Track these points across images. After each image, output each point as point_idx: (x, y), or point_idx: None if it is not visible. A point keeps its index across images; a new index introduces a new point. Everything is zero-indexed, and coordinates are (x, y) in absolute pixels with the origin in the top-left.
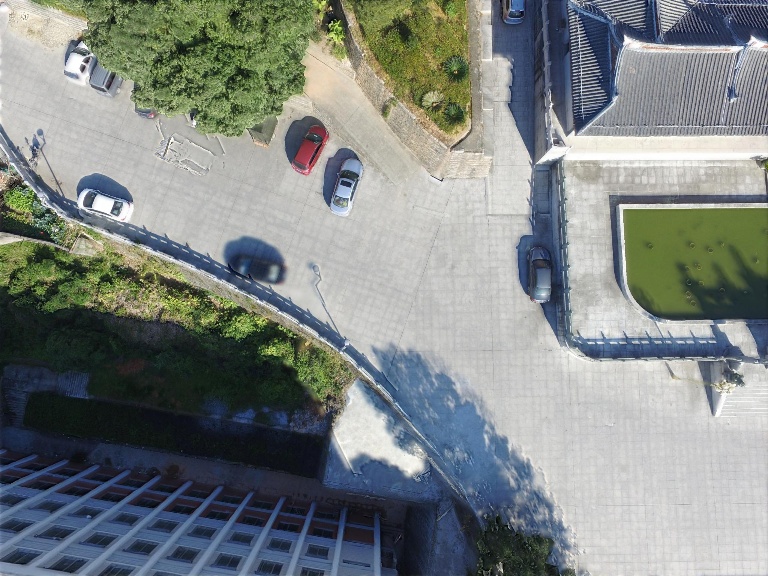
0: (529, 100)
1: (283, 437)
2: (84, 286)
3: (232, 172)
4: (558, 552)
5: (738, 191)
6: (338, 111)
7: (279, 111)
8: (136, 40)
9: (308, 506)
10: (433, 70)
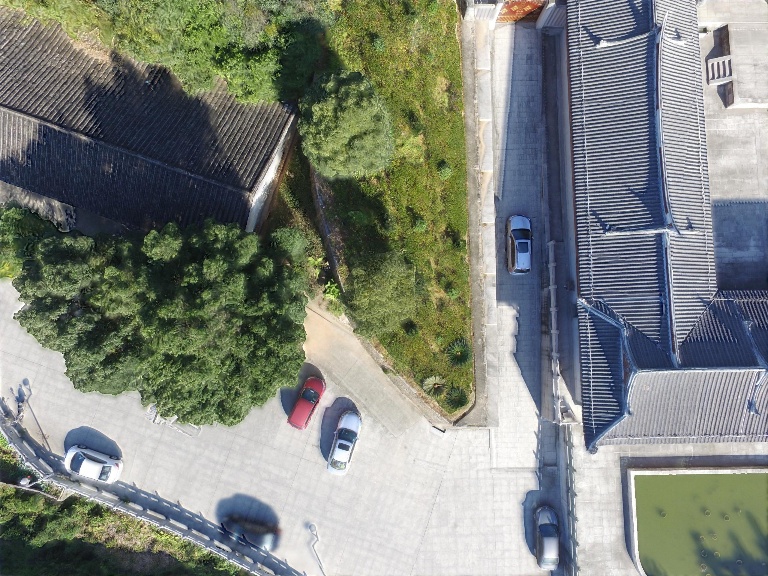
0: (535, 349)
1: None
2: (74, 520)
3: None
4: None
5: (756, 451)
6: (335, 366)
7: (273, 395)
8: (119, 388)
9: None
10: (435, 352)
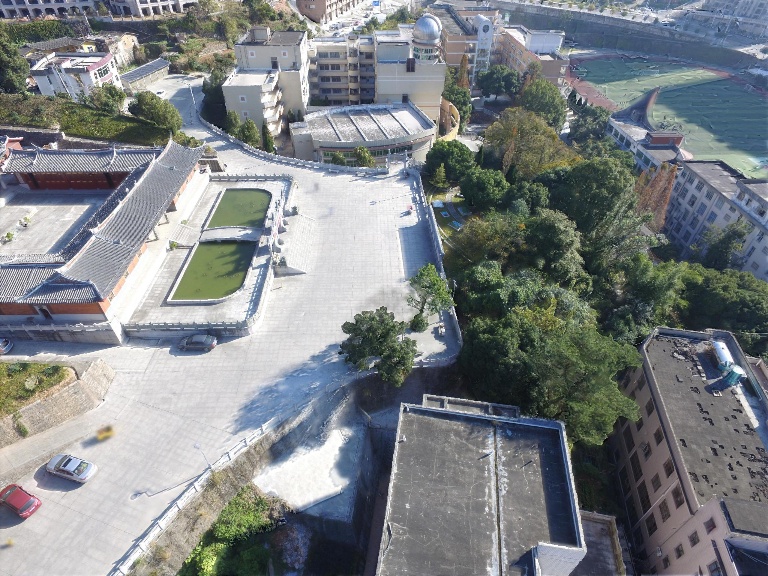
0: (73, 345)
1: None
2: None
3: None
4: None
5: (183, 258)
6: None
7: None
8: None
9: None
10: None
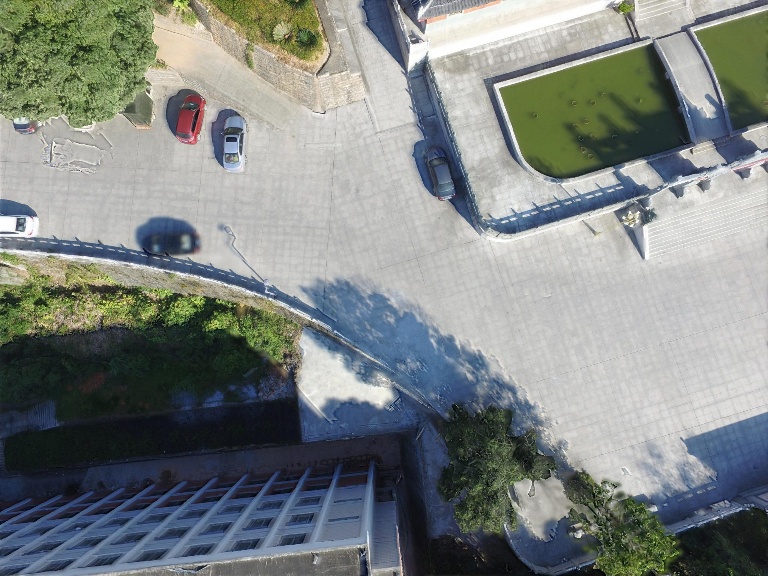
0: (384, 14)
1: (257, 410)
2: (20, 315)
3: (124, 162)
4: None
5: (604, 41)
6: (206, 75)
7: (141, 84)
8: None
9: (303, 472)
10: (275, 4)
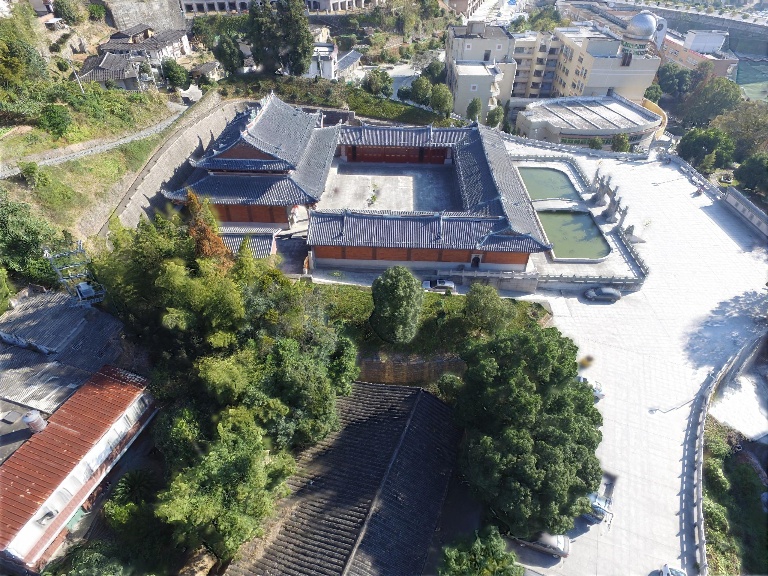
0: None
1: None
2: None
3: None
4: (761, 299)
5: None
6: None
7: None
8: None
9: None
10: None
